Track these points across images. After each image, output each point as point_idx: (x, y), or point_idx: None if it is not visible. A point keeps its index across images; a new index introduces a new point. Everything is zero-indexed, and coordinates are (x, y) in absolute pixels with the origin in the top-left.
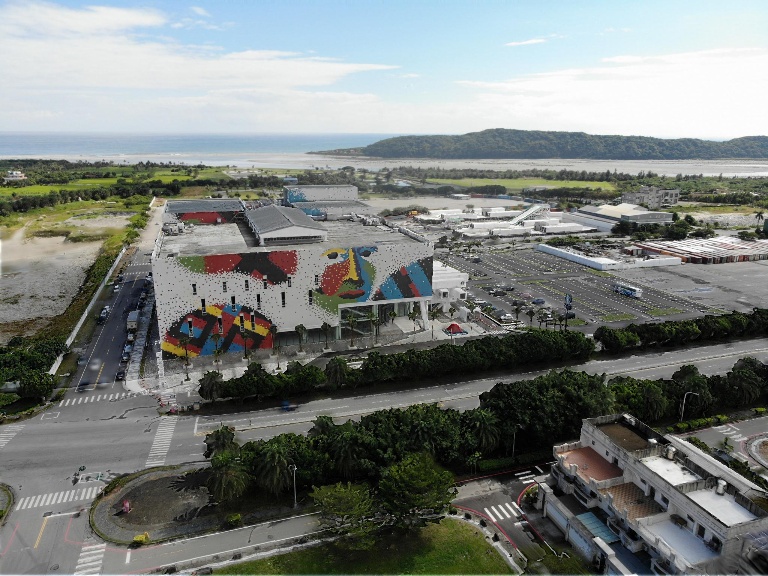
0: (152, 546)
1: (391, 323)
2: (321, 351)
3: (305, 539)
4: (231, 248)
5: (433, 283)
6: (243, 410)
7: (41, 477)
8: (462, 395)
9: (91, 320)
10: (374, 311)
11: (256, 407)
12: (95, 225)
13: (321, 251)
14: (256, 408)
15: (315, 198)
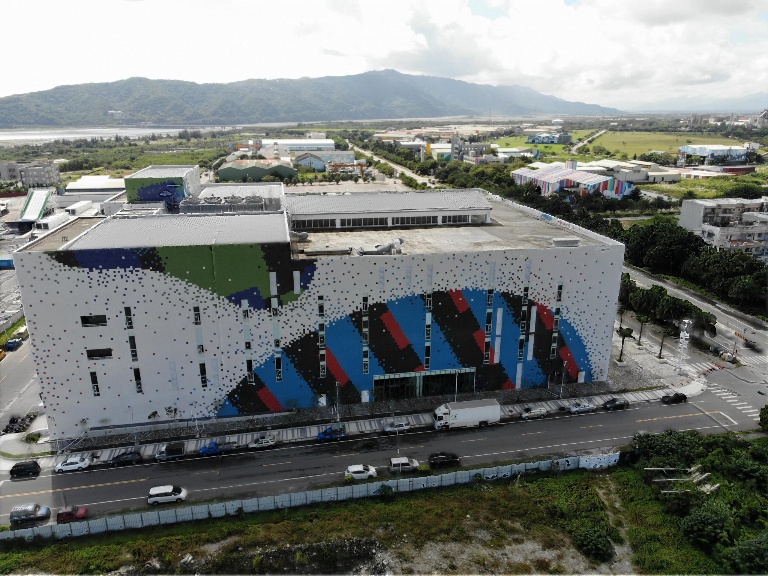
0: None
1: None
2: None
3: None
4: None
5: None
6: None
7: None
8: None
9: None
10: None
11: None
12: None
13: None
14: None
15: (191, 189)
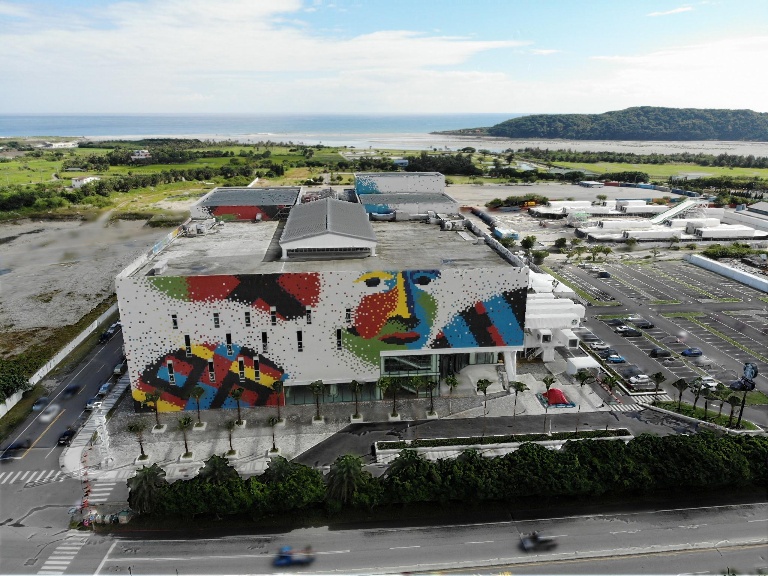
0: None
1: (462, 375)
2: (347, 420)
3: None
4: (240, 262)
5: (529, 320)
6: (187, 534)
7: None
8: (547, 555)
9: (95, 336)
10: (433, 363)
11: (209, 530)
12: (181, 208)
13: (355, 275)
14: (208, 533)
15: (390, 189)
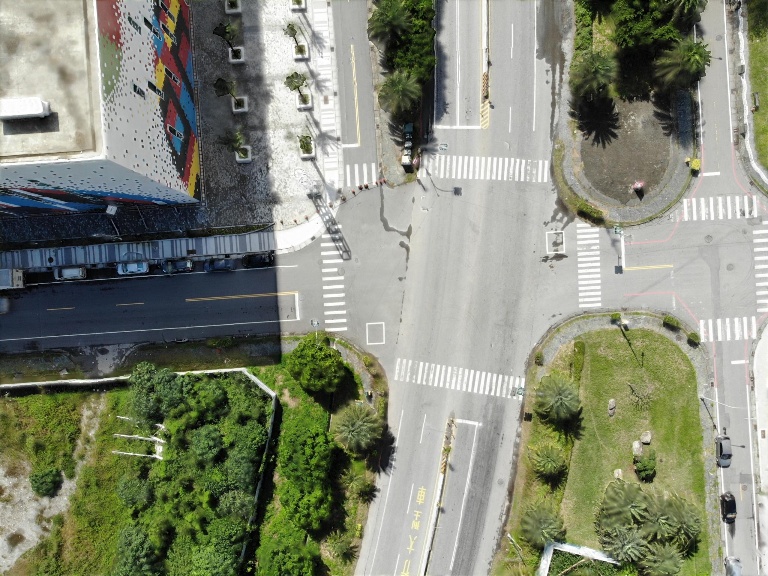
0: (701, 154)
1: None
2: None
3: (740, 2)
4: None
5: None
6: None
7: (541, 299)
8: None
9: None
10: None
11: None
12: None
13: None
14: None
15: None
